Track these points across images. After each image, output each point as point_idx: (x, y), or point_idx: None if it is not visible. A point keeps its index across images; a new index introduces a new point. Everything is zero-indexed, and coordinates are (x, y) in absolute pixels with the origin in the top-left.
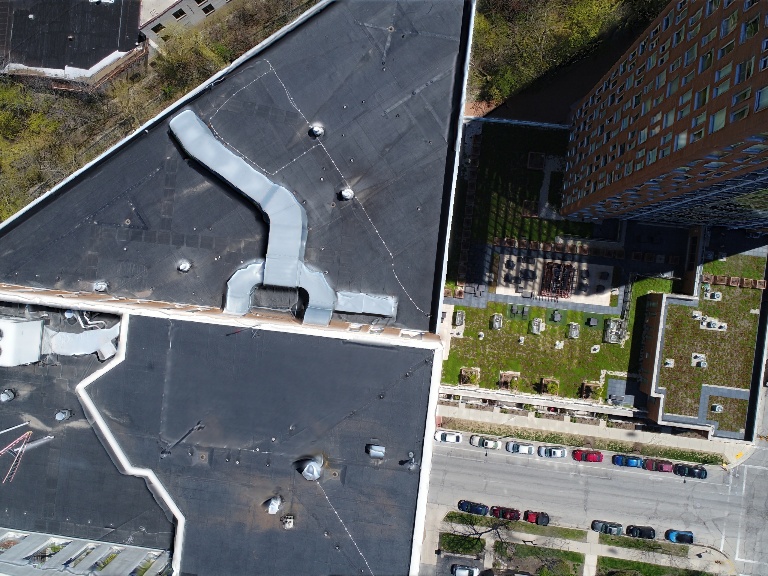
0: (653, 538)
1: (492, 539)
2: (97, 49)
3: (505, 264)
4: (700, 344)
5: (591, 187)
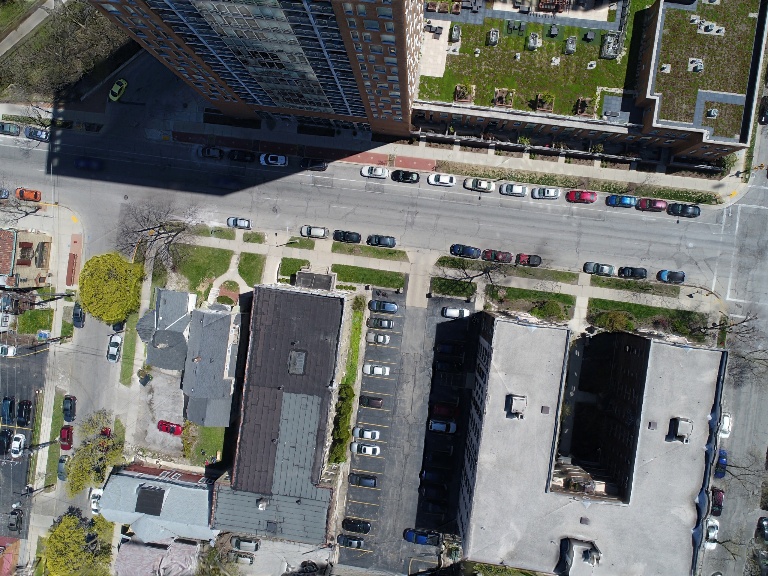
0: (645, 279)
1: (483, 283)
2: None
3: None
4: (697, 49)
5: None
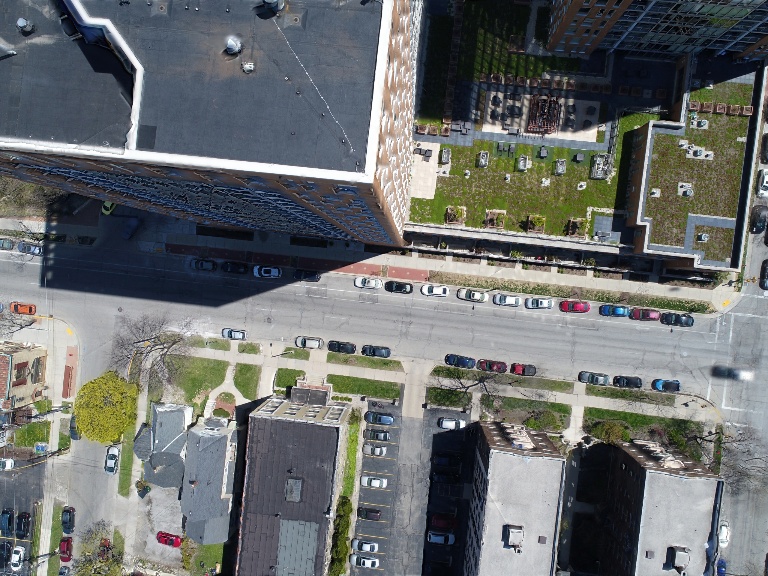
0: (640, 388)
1: (479, 392)
2: None
3: (491, 100)
4: (686, 173)
5: None
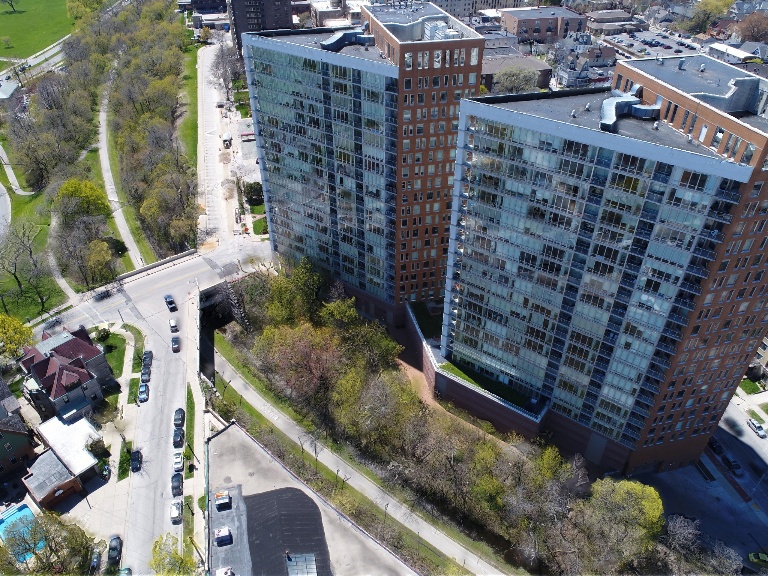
0: None
1: None
2: None
3: None
4: None
5: None
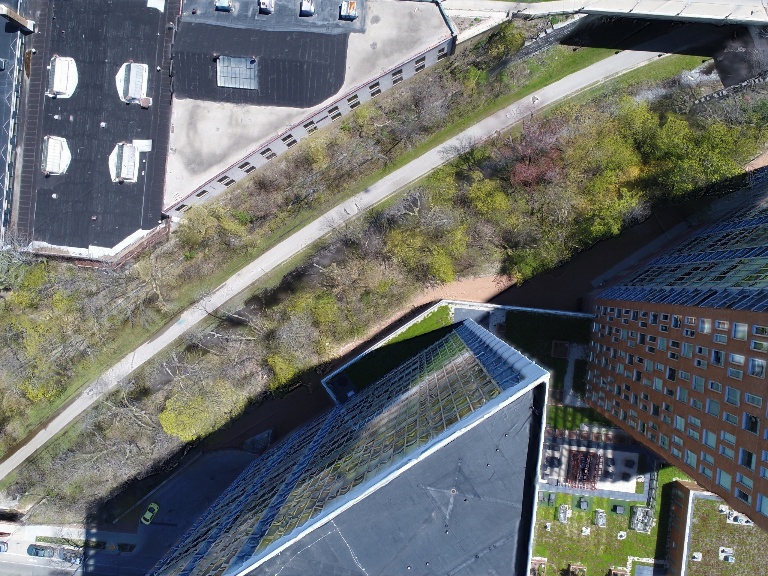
0: None
1: None
2: (120, 228)
3: None
4: (727, 538)
5: (620, 413)
